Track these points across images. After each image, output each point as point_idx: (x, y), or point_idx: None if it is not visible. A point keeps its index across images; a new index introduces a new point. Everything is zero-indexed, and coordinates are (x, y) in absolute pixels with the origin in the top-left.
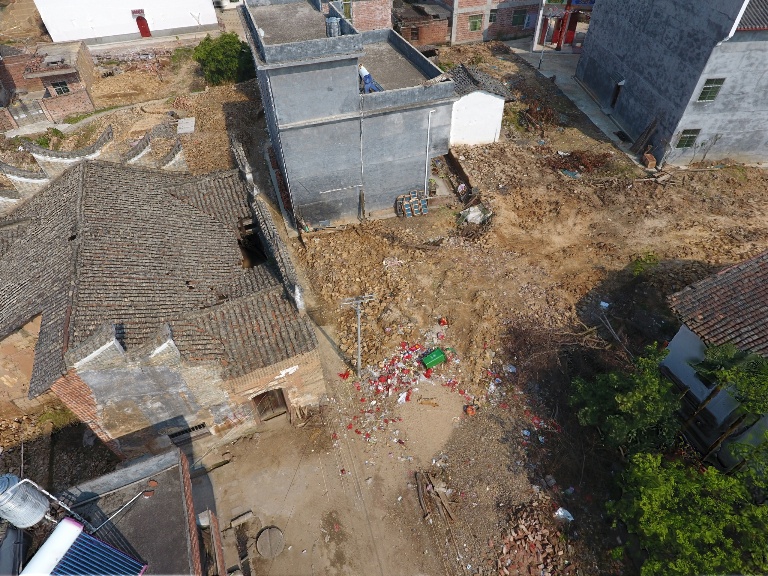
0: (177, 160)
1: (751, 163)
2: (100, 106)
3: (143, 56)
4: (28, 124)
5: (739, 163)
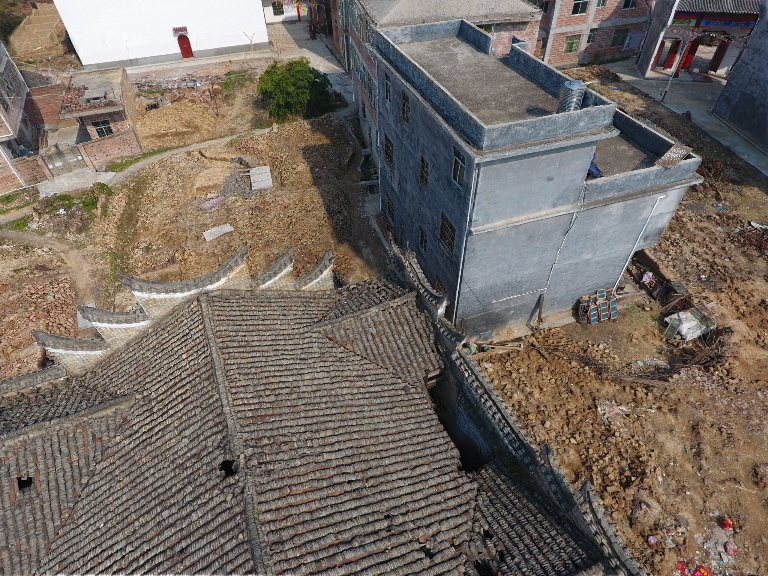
0: (323, 277)
1: None
2: (148, 148)
3: (190, 83)
4: (64, 173)
5: None
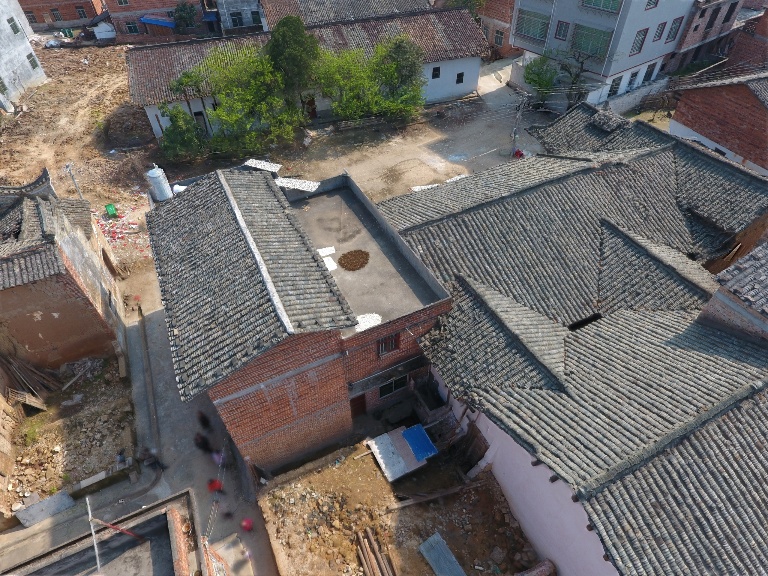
0: None
1: (39, 85)
2: None
3: None
4: None
5: (36, 87)
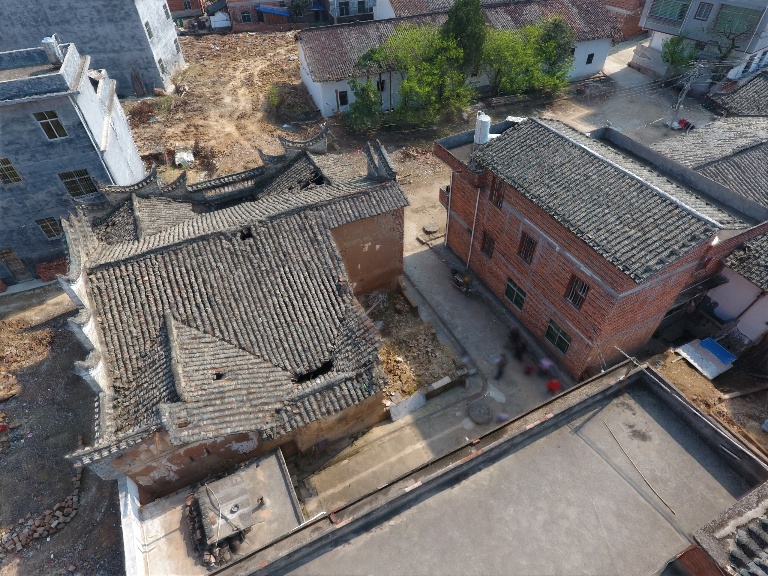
0: None
1: None
2: None
3: None
4: None
5: (181, 70)
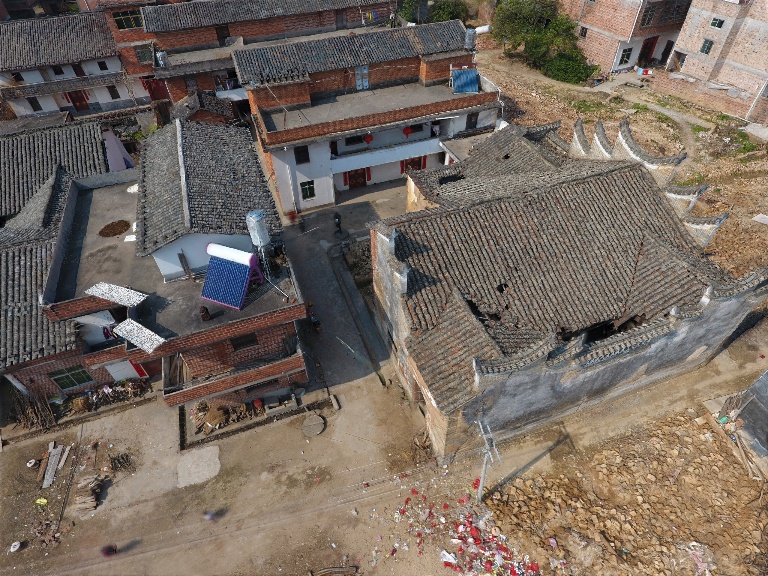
0: (704, 229)
1: None
2: None
3: None
4: None
5: None
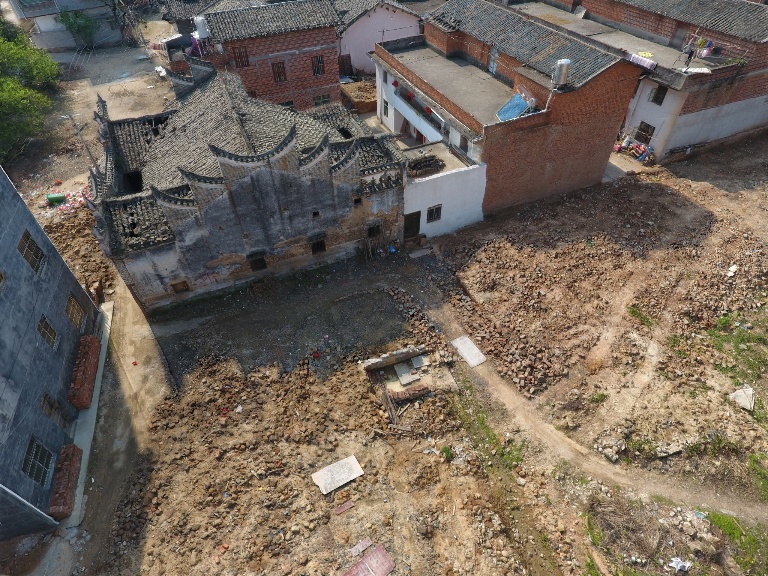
0: None
1: None
2: None
3: None
4: None
5: None
